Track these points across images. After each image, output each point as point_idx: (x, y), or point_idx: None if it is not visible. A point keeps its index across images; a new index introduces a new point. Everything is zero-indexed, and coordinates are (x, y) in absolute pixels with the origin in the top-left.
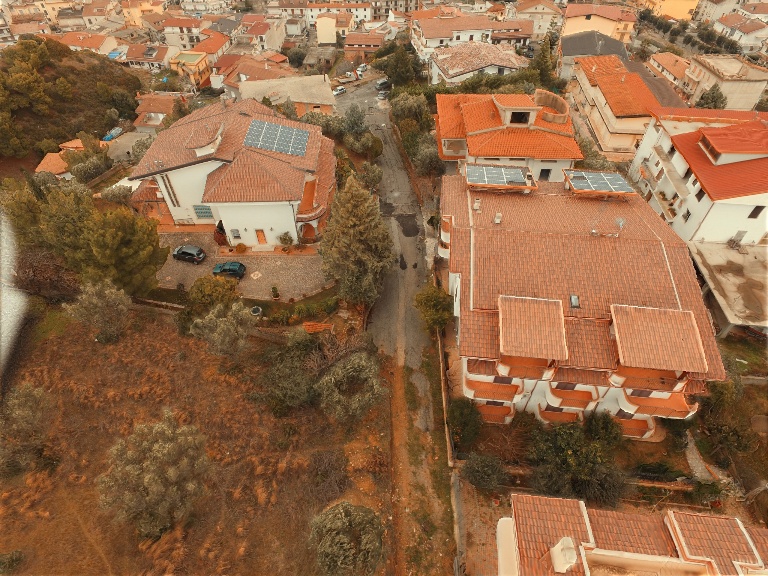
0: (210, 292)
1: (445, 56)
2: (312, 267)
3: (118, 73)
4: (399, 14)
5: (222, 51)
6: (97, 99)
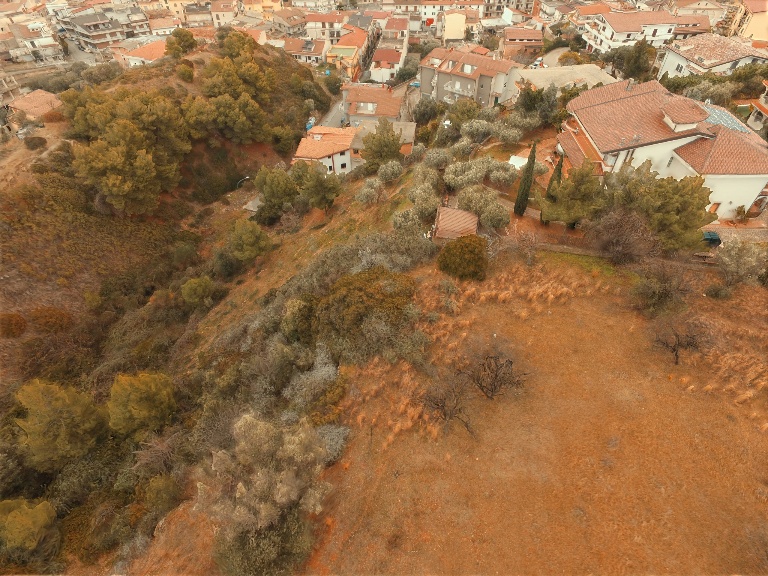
0: None
1: (688, 47)
2: None
3: (295, 65)
4: (517, 11)
5: (364, 46)
6: (289, 90)
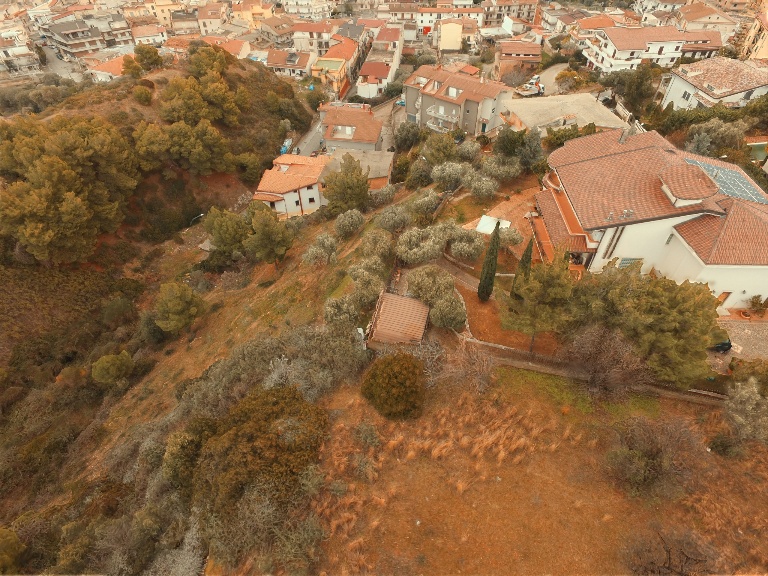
0: None
1: (696, 73)
2: None
3: (274, 81)
4: (517, 20)
5: (353, 57)
6: (265, 109)
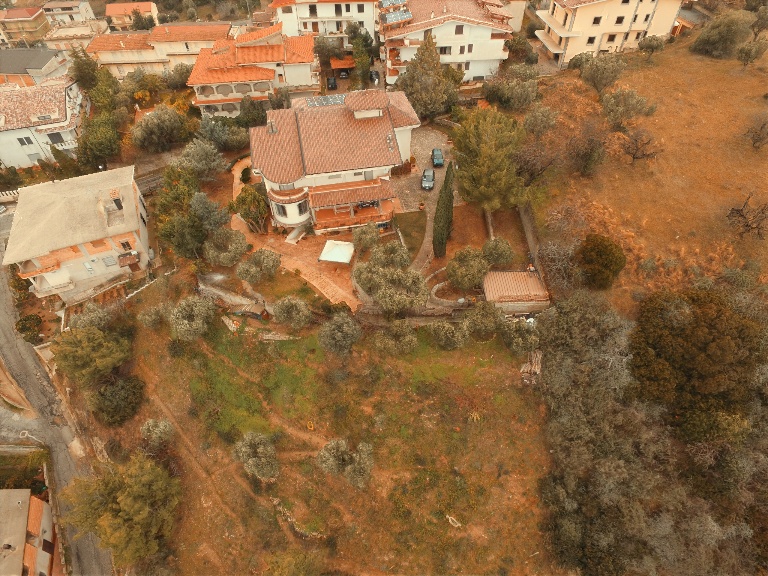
0: None
1: (2, 119)
2: (415, 136)
3: None
4: None
5: None
6: None
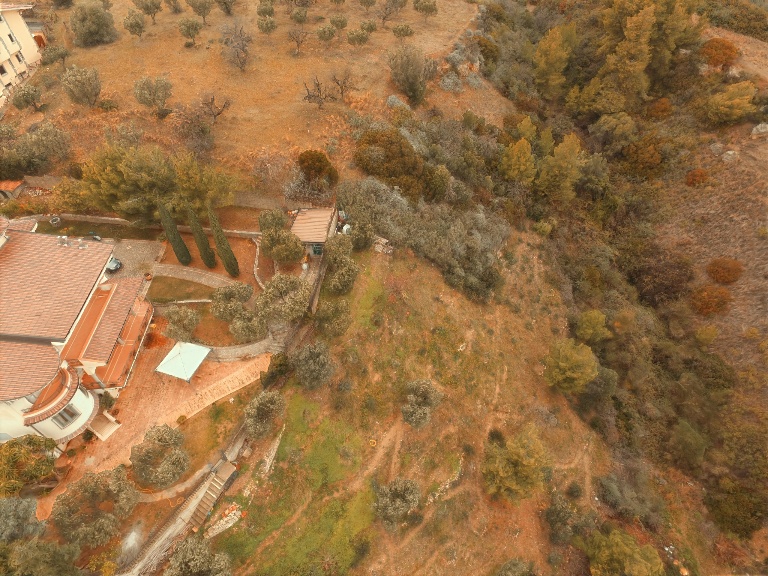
0: None
1: None
2: None
3: None
4: None
5: None
6: None
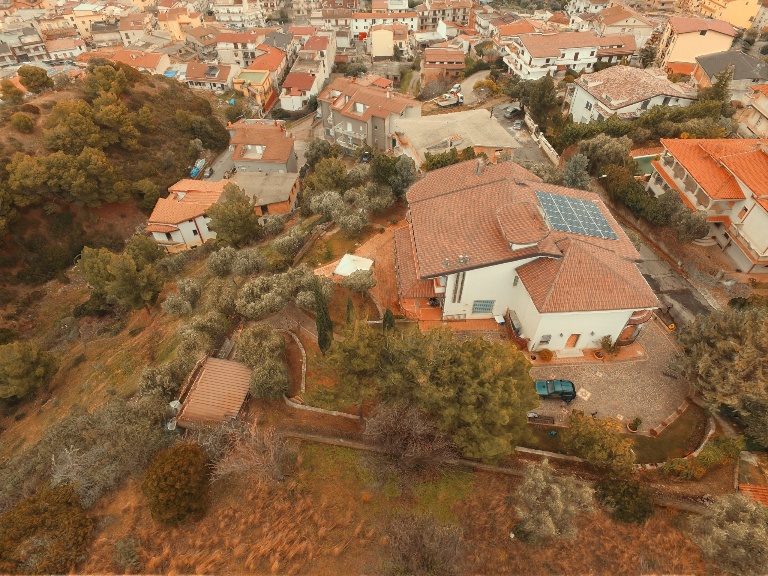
0: (623, 451)
1: (597, 83)
2: (643, 379)
3: (189, 97)
4: (451, 24)
5: (280, 68)
6: (175, 128)
